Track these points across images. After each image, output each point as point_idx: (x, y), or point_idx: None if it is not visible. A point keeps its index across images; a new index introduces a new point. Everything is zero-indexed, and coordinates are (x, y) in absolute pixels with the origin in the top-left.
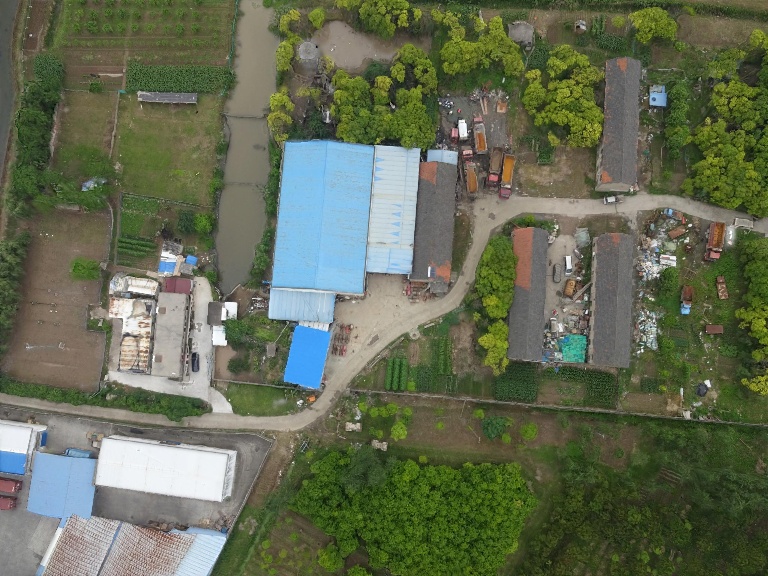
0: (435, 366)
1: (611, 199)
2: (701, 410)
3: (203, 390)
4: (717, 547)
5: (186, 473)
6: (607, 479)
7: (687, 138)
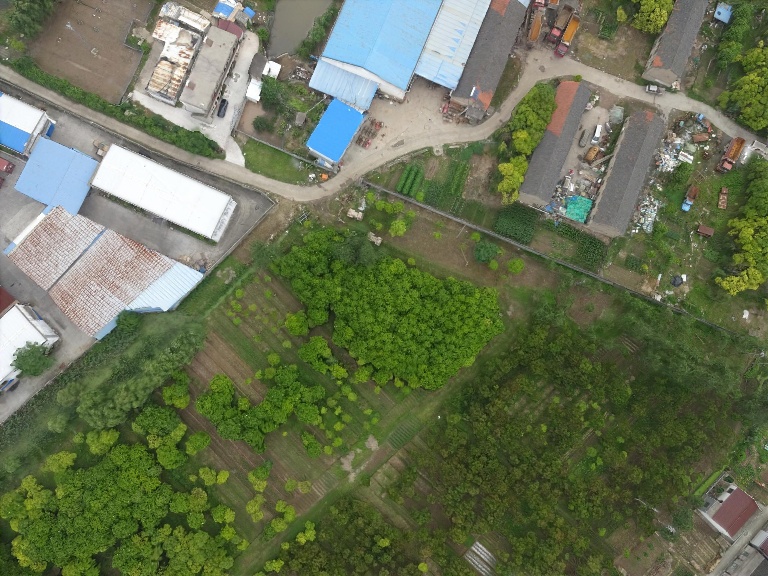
0: (448, 185)
1: (653, 87)
2: (671, 298)
3: (222, 137)
4: (646, 420)
5: (185, 201)
6: (571, 330)
7: (737, 56)
